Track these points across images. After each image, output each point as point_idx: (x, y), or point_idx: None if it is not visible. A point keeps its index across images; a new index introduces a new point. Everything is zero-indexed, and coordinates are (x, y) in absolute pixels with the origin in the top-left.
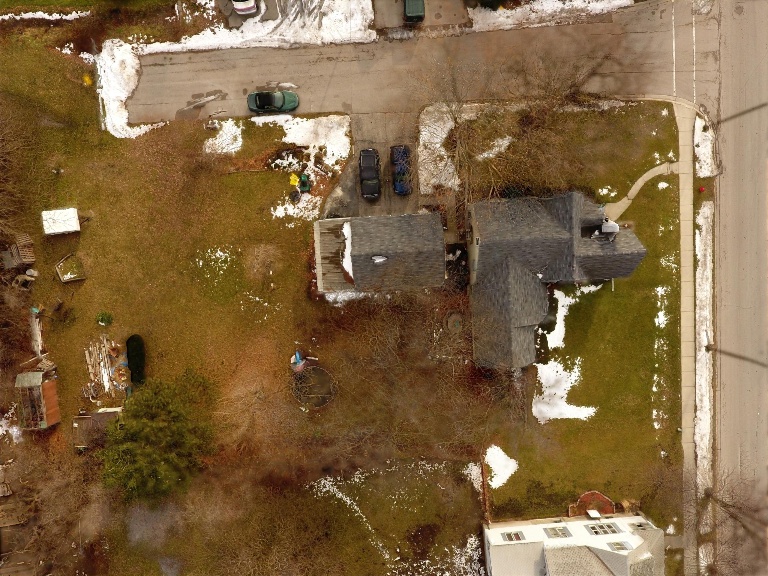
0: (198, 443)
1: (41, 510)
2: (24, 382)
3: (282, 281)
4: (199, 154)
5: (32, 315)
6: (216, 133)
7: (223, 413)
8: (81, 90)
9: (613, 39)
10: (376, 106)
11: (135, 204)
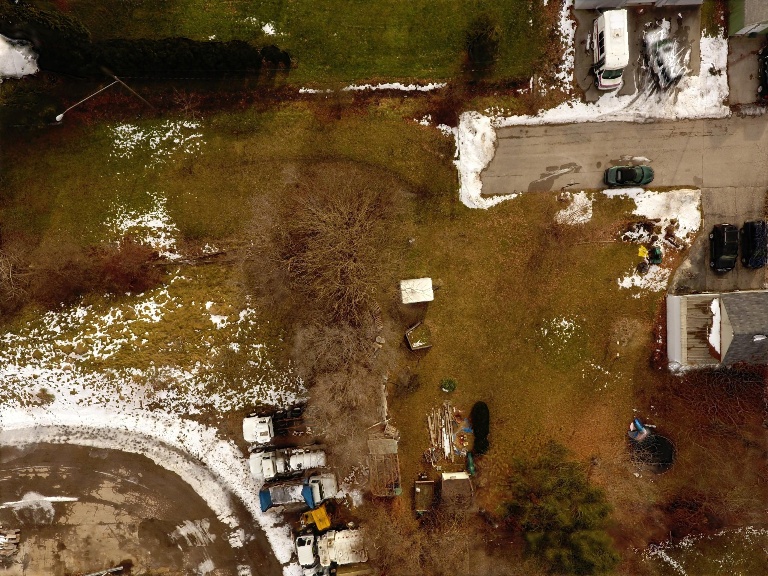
0: (532, 507)
1: (385, 574)
2: (379, 449)
3: (625, 350)
4: (550, 225)
5: (380, 382)
6: (567, 205)
7: (557, 478)
8: (438, 161)
9: None
10: (726, 180)
11: (483, 273)
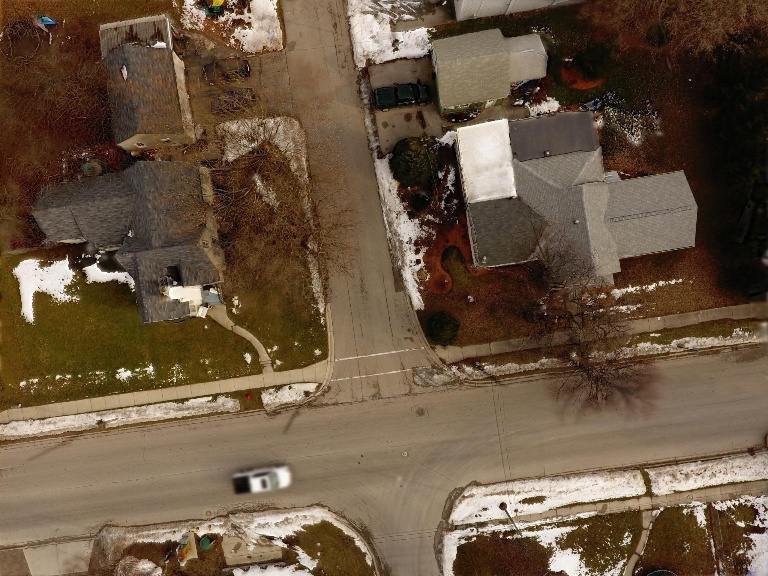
0: None
1: None
2: None
3: (121, 1)
4: None
5: None
6: None
7: None
8: None
9: (381, 295)
10: (295, 74)
11: None
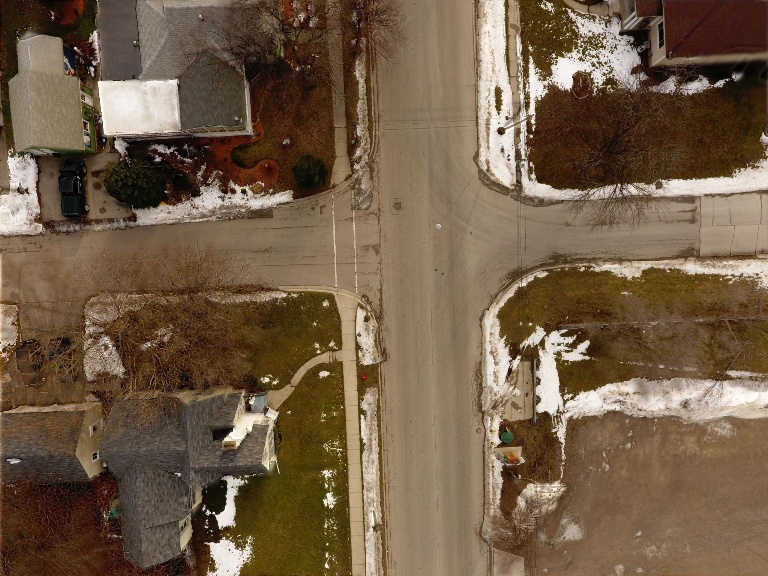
0: None
1: None
2: None
3: None
4: None
5: None
6: None
7: None
8: None
9: (274, 233)
10: (44, 296)
11: None
